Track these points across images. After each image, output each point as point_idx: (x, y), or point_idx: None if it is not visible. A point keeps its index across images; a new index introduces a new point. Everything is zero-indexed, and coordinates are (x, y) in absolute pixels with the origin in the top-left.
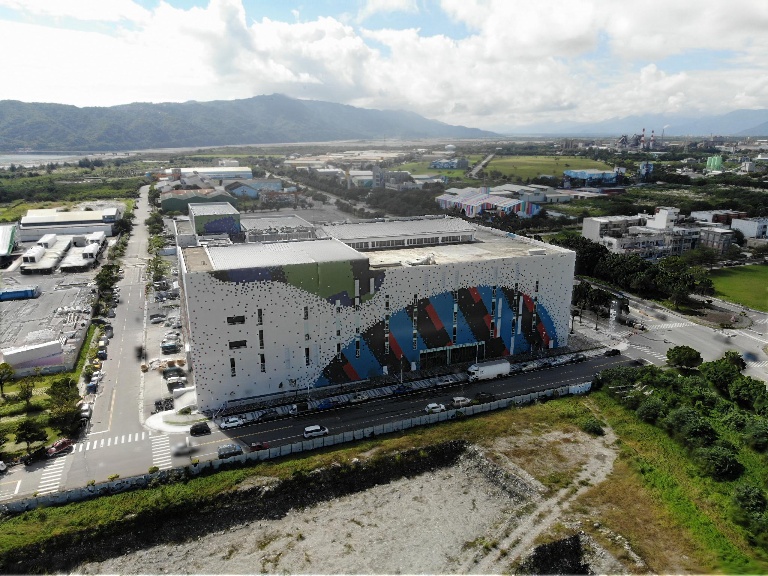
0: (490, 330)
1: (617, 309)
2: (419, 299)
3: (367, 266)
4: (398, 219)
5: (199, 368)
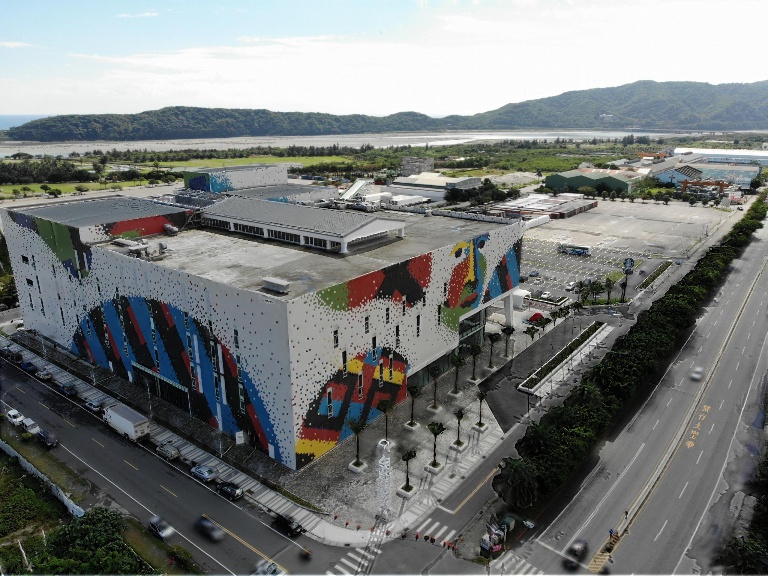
0: (192, 376)
1: (496, 480)
2: (121, 295)
3: (79, 237)
4: (451, 214)
5: (19, 293)
